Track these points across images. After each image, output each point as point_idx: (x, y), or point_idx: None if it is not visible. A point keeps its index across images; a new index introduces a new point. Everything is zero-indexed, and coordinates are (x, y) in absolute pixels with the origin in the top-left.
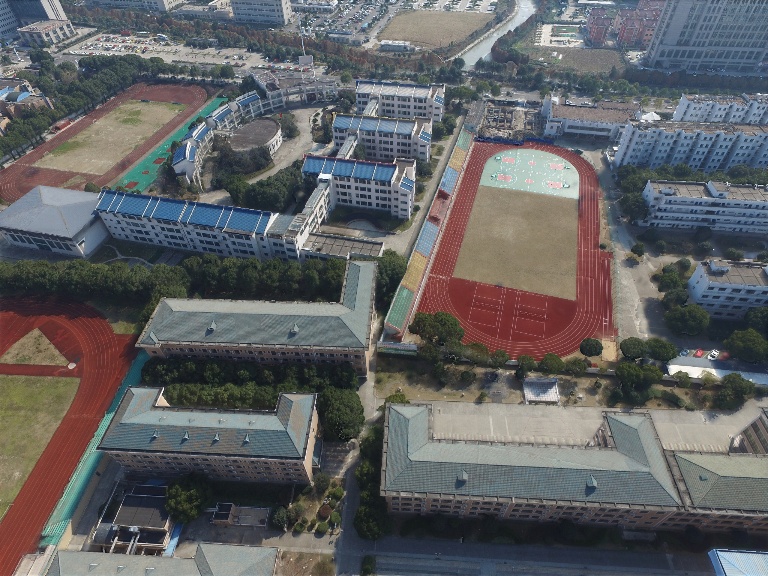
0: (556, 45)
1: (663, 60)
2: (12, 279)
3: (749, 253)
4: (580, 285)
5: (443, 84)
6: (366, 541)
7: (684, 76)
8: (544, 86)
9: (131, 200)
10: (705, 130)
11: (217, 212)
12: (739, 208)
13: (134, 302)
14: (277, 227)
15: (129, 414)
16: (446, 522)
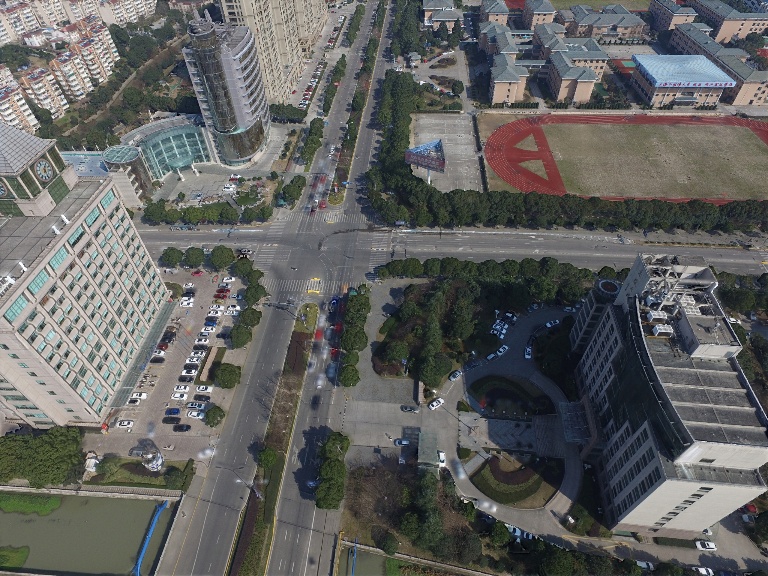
0: None
1: None
2: None
3: None
4: None
5: None
6: (656, 44)
7: None
8: None
9: None
10: None
11: None
12: None
13: None
14: None
15: None
16: None
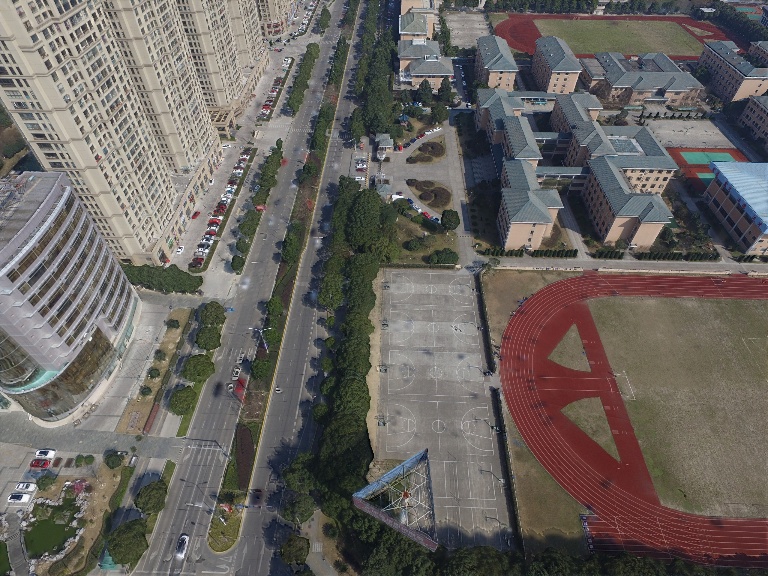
0: None
1: None
2: (743, 23)
3: None
4: None
5: None
6: (720, 118)
7: None
8: None
9: None
10: None
11: None
12: None
13: None
14: None
15: (724, 42)
16: (748, 134)
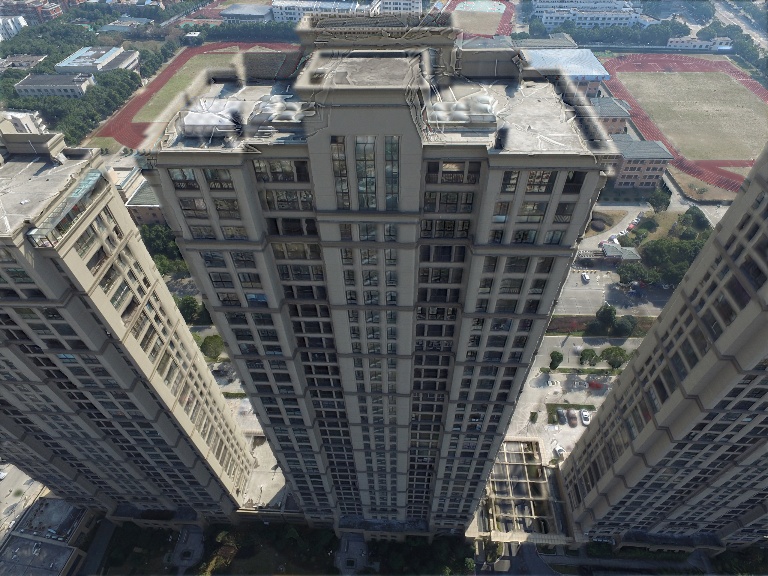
0: None
1: None
2: (242, 28)
3: None
4: (497, 32)
5: None
6: None
7: None
8: None
9: (289, 1)
10: None
11: (332, 3)
12: (572, 3)
13: (297, 39)
14: (360, 8)
15: None
16: None
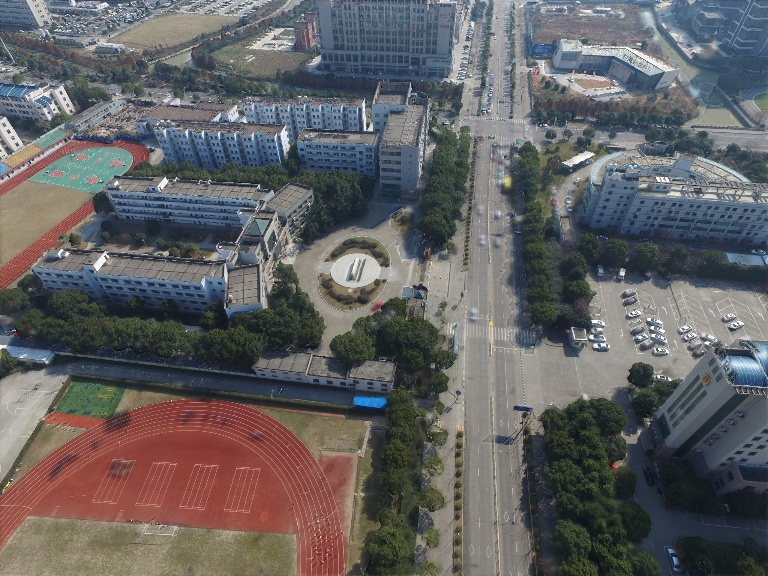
0: (264, 48)
1: (328, 63)
2: None
3: (184, 244)
4: None
5: (60, 85)
6: None
7: (329, 79)
8: (196, 87)
9: None
10: (214, 130)
11: None
12: (174, 202)
13: None
14: None
15: None
16: None
